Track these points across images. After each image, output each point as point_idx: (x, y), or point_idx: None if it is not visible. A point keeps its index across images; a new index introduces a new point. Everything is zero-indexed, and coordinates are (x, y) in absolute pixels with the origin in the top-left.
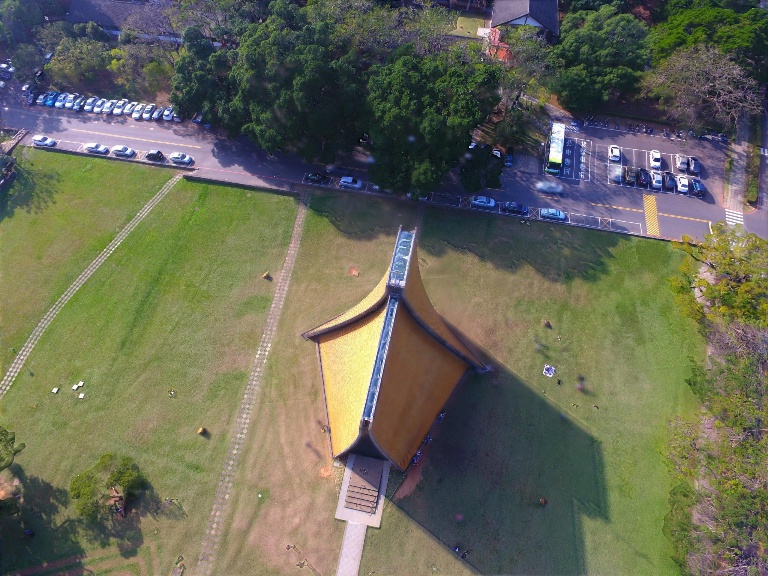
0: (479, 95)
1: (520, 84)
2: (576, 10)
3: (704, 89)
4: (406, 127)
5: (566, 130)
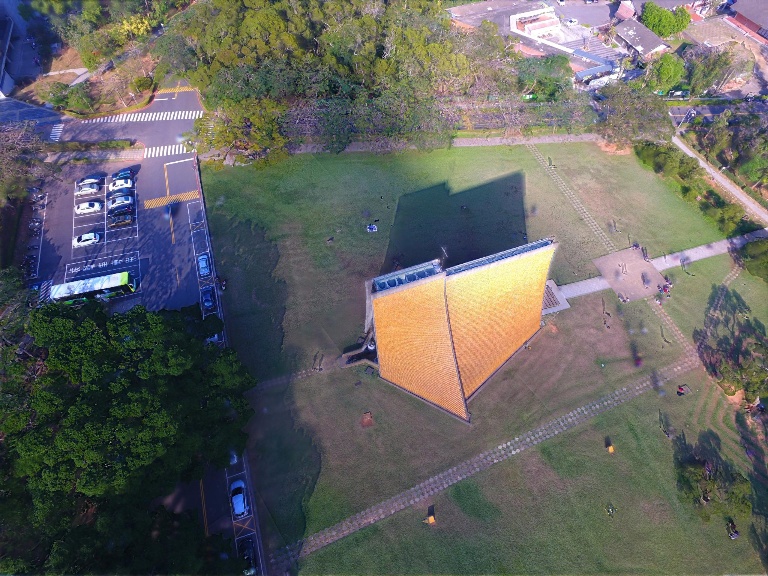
0: None
1: None
2: None
3: (8, 152)
4: None
5: None
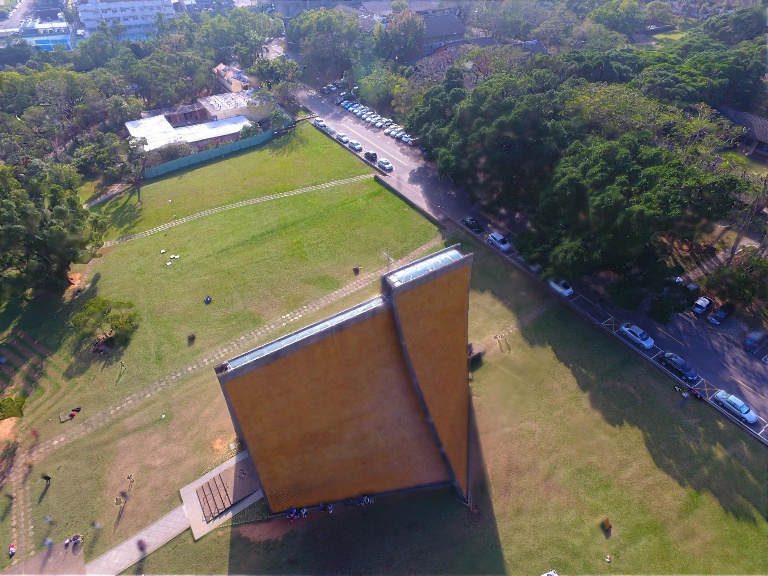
0: (699, 202)
1: None
2: None
3: None
4: (579, 198)
5: None
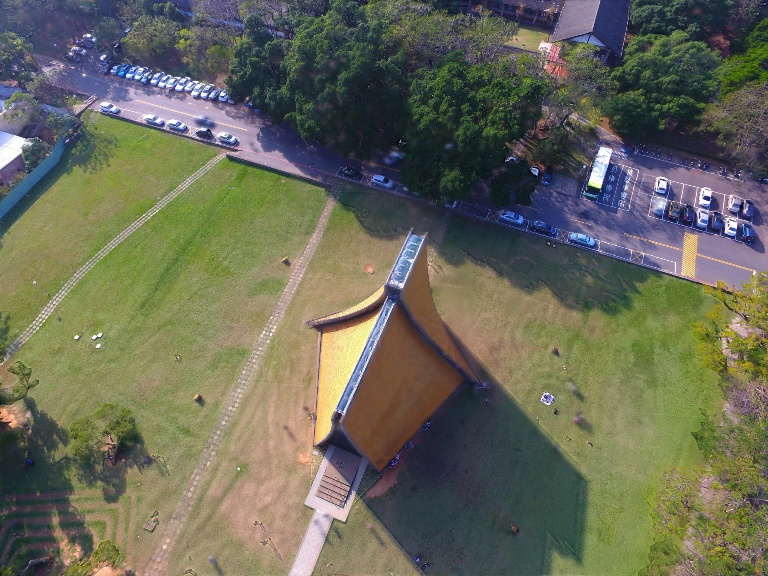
0: (521, 109)
1: (568, 103)
2: (646, 33)
3: None
4: (441, 133)
5: (614, 155)
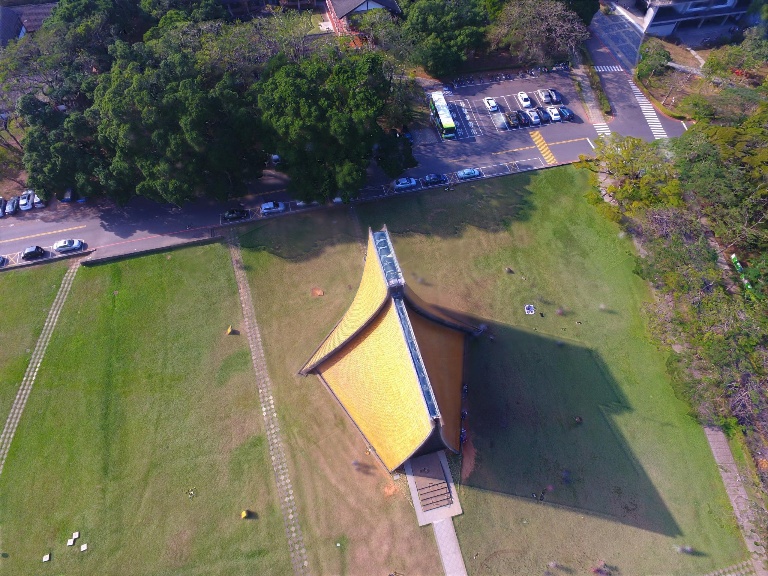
0: (369, 85)
1: None
2: None
3: (543, 29)
4: (314, 135)
5: None
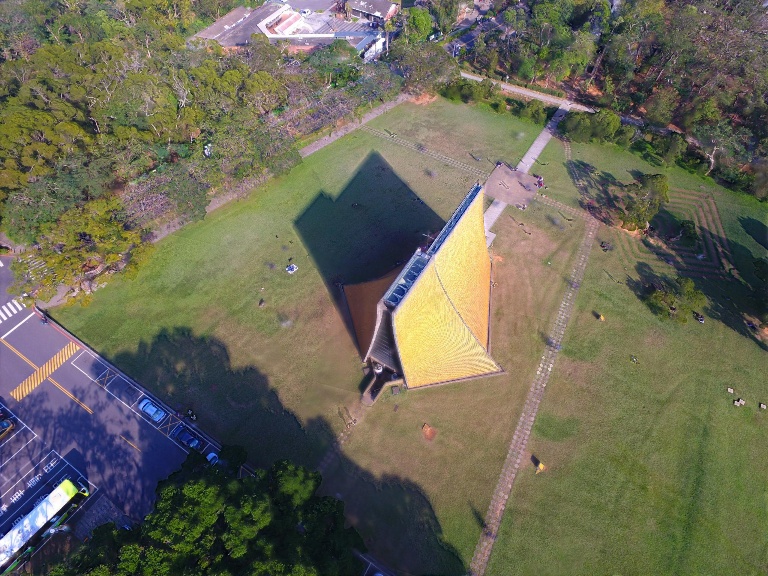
0: None
1: None
2: None
3: None
4: None
5: None
